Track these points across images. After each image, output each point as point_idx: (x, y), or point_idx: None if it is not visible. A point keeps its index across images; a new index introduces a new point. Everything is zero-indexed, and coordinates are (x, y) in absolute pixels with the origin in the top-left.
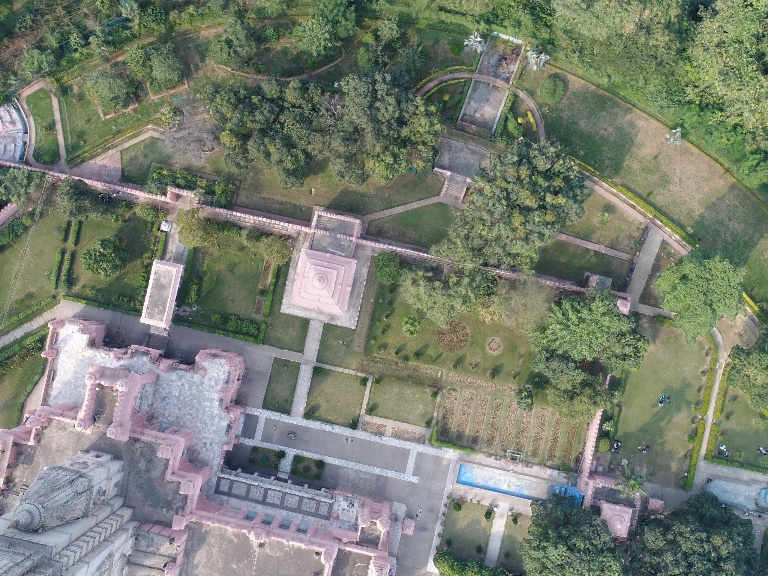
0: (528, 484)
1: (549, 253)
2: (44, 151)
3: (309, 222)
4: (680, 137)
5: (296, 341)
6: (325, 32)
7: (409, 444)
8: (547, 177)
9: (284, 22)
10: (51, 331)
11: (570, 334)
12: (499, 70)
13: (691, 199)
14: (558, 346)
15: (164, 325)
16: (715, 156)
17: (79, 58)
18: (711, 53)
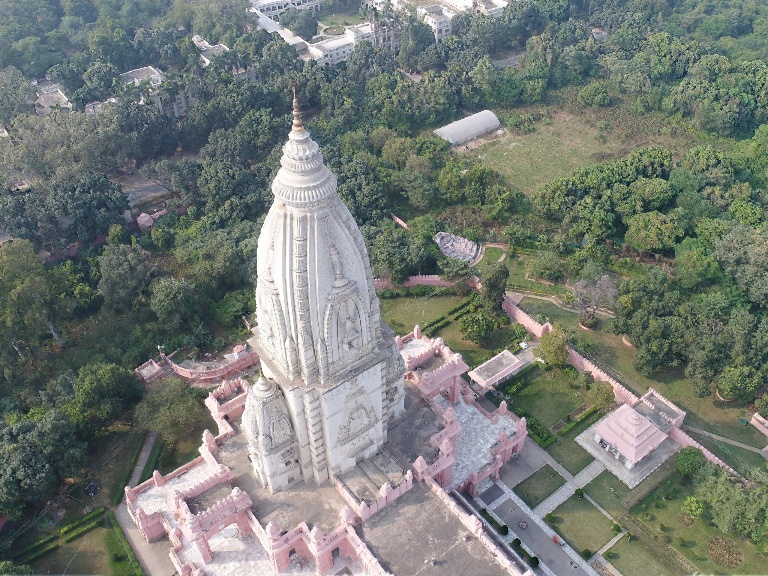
0: None
1: None
2: None
3: None
4: None
5: (573, 465)
6: (723, 302)
7: None
8: None
9: None
10: (411, 334)
11: None
12: None
13: None
14: None
15: (484, 384)
16: None
17: (538, 245)
18: None
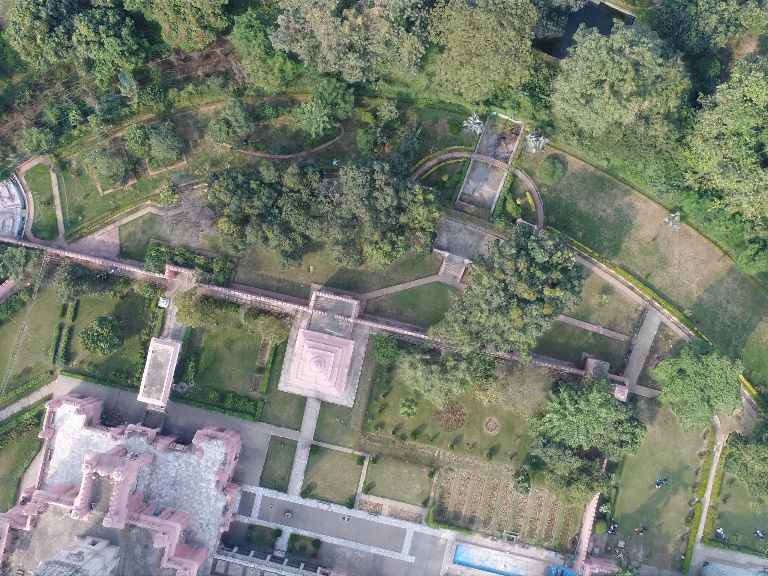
0: (524, 565)
1: (547, 333)
2: (42, 226)
3: (307, 300)
4: (679, 221)
5: (293, 419)
6: (324, 115)
7: (406, 523)
8: (545, 268)
9: (283, 99)
10: (48, 411)
11: (567, 424)
12: (498, 150)
13: (690, 281)
14: (555, 434)
15: (161, 404)
16: (714, 239)
17: (78, 135)
18: (710, 145)
